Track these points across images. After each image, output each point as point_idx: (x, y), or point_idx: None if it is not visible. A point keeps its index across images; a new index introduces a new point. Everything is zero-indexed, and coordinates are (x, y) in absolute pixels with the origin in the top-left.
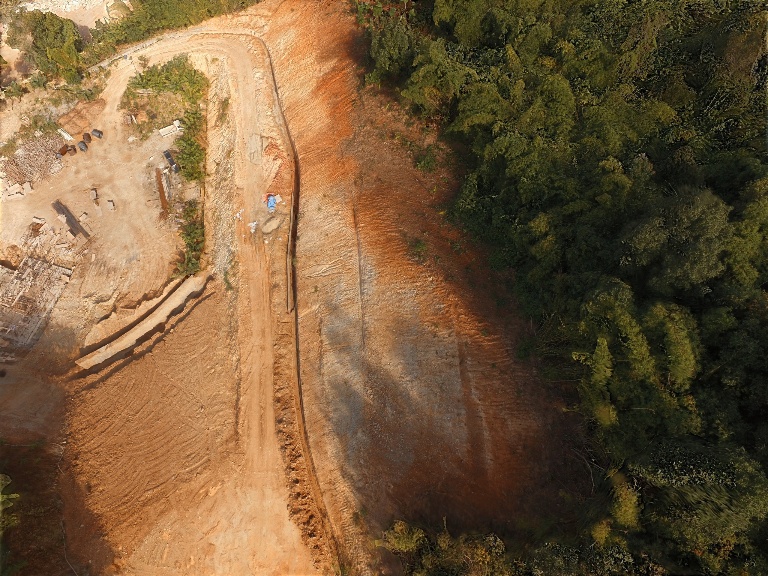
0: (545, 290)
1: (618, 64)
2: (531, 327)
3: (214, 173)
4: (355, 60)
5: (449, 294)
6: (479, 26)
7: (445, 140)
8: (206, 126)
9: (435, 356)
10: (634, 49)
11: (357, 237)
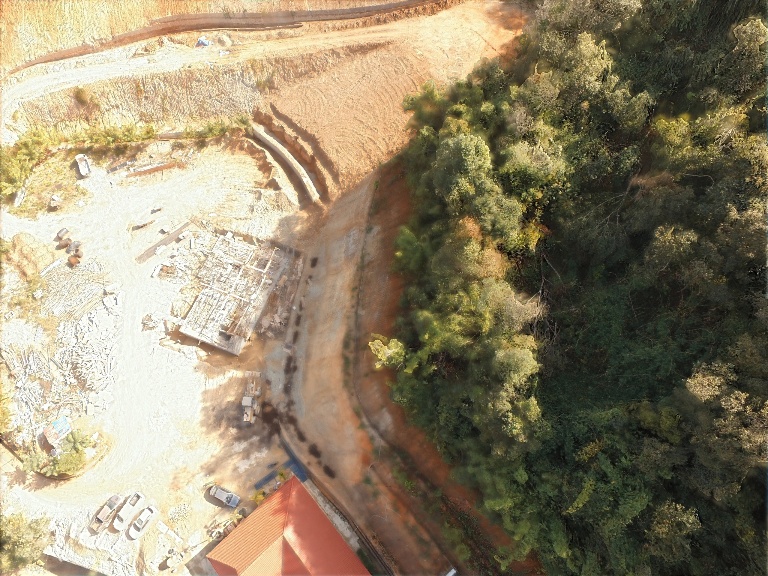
0: None
1: None
2: None
3: None
4: None
5: None
6: None
7: None
8: None
9: None
10: None
11: None
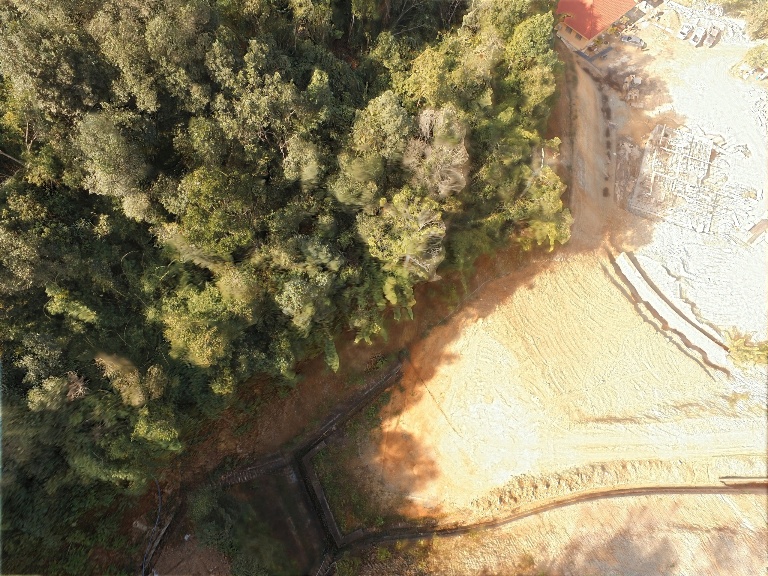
0: None
1: None
2: None
3: None
4: None
5: None
6: None
7: None
8: None
9: None
10: None
11: None
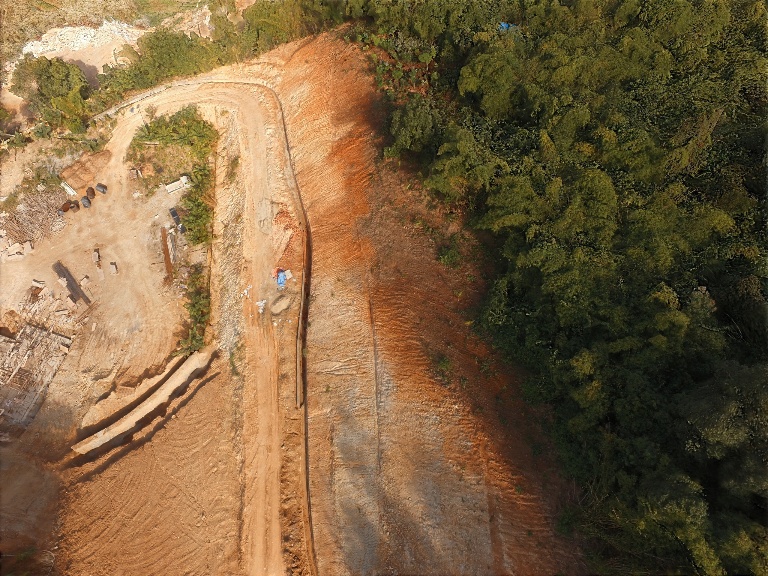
0: (590, 446)
1: (667, 161)
2: (574, 492)
3: (222, 235)
4: (373, 127)
5: (477, 431)
6: (508, 99)
7: (471, 229)
8: (214, 181)
9: (461, 504)
10: (686, 145)
11: (373, 336)
